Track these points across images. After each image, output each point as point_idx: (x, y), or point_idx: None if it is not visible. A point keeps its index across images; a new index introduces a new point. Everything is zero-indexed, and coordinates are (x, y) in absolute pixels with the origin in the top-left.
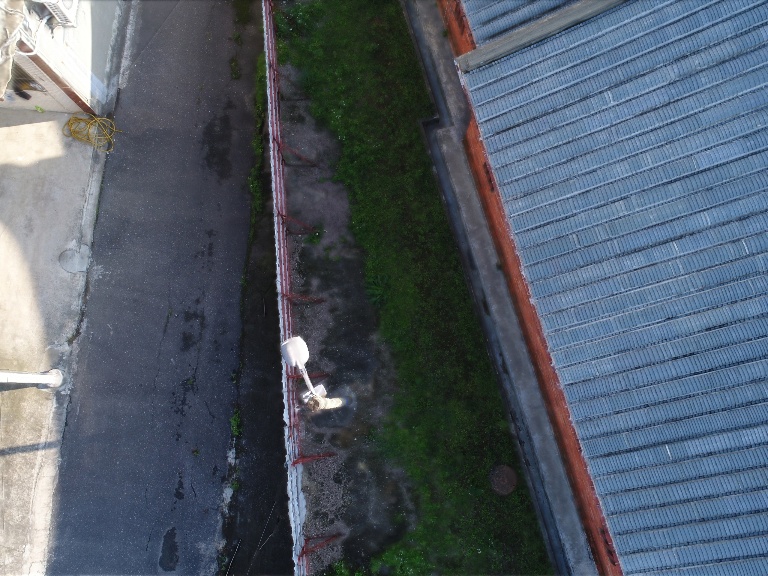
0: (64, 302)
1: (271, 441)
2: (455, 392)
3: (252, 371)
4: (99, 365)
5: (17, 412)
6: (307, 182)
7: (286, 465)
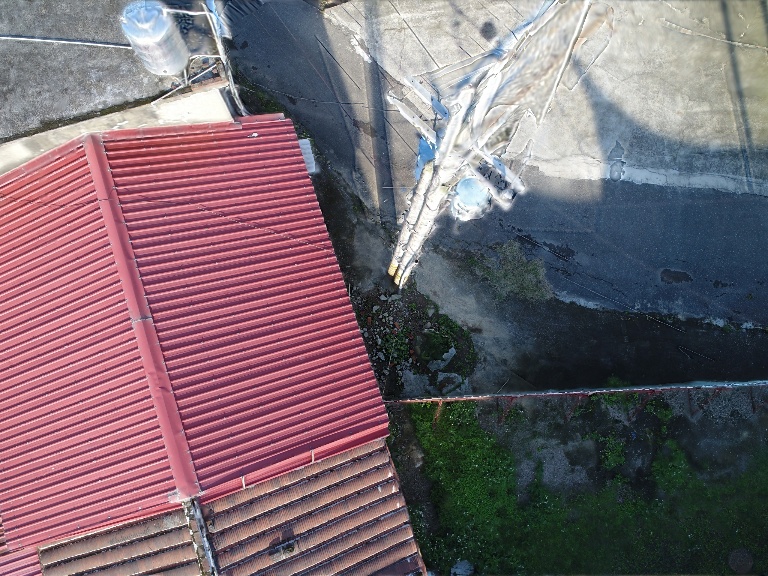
0: None
1: (761, 358)
2: None
3: None
4: None
5: None
6: None
7: None
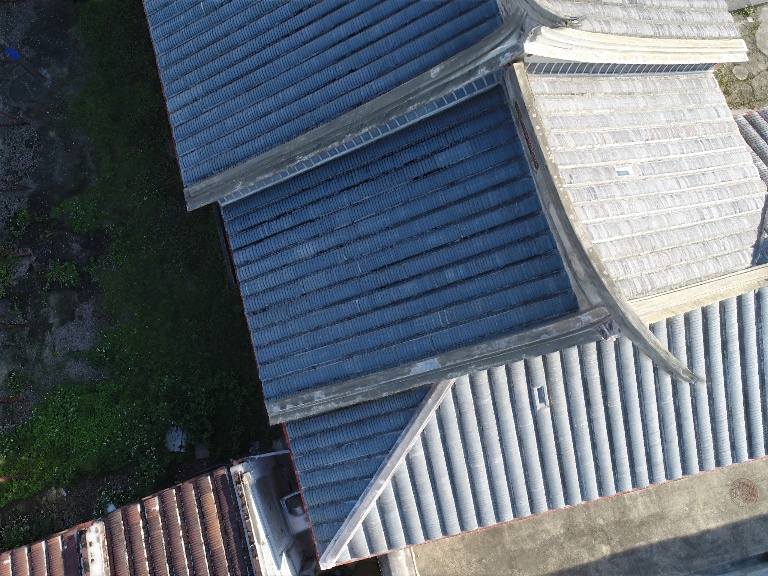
0: None
1: None
2: (142, 76)
3: None
4: None
5: None
6: None
7: None
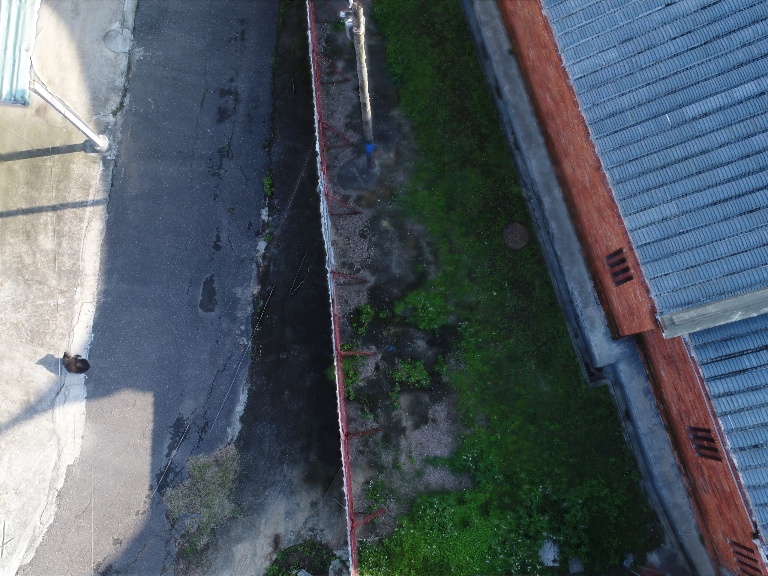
0: (109, 78)
1: (301, 201)
2: (471, 161)
3: (283, 141)
4: (141, 134)
5: (67, 173)
6: None
7: (319, 189)
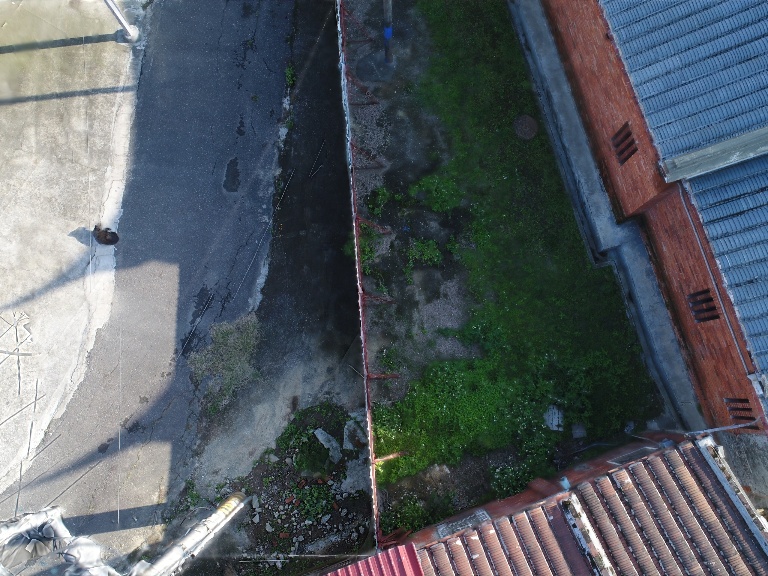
0: None
1: (321, 92)
2: (483, 57)
3: (304, 36)
4: (170, 27)
5: (99, 61)
6: None
7: (340, 65)
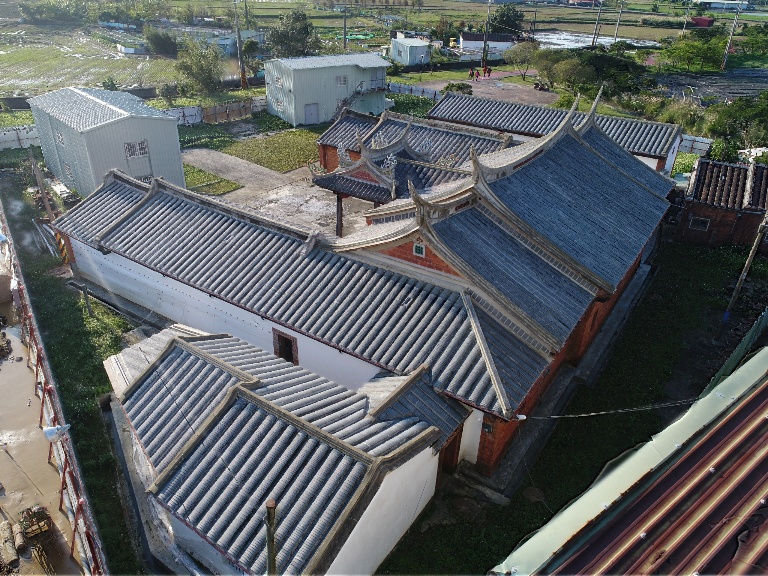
0: None
1: None
2: None
3: None
4: None
5: None
6: (686, 405)
7: None
